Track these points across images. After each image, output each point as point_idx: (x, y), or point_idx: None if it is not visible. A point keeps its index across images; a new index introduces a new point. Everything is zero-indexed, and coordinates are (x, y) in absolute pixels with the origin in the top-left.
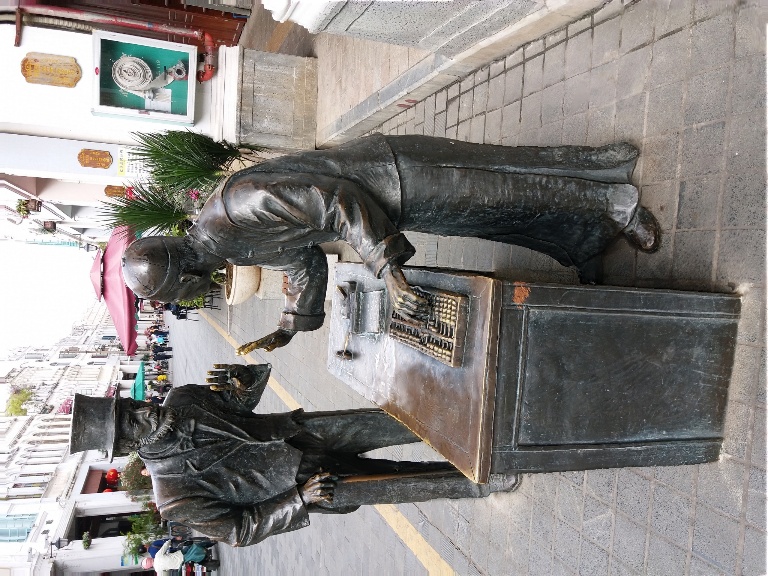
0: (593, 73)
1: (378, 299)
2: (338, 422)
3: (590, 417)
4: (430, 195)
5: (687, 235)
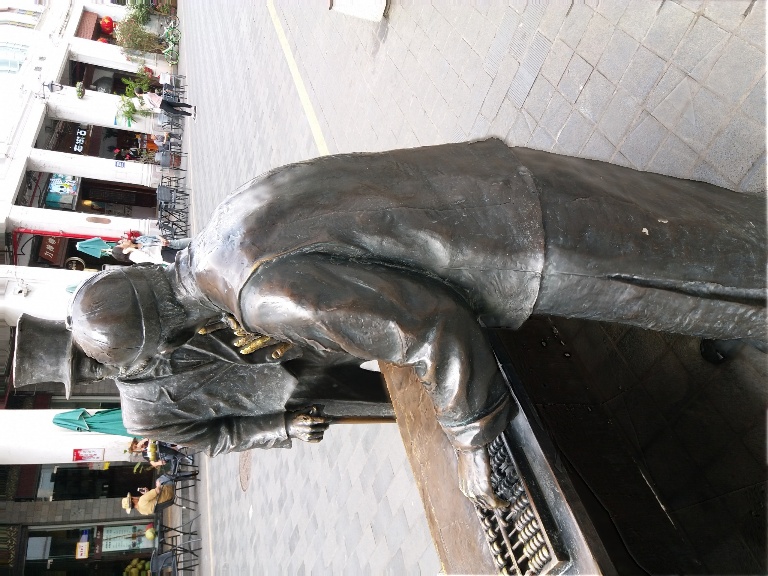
0: None
1: None
2: None
3: None
4: (573, 310)
5: None
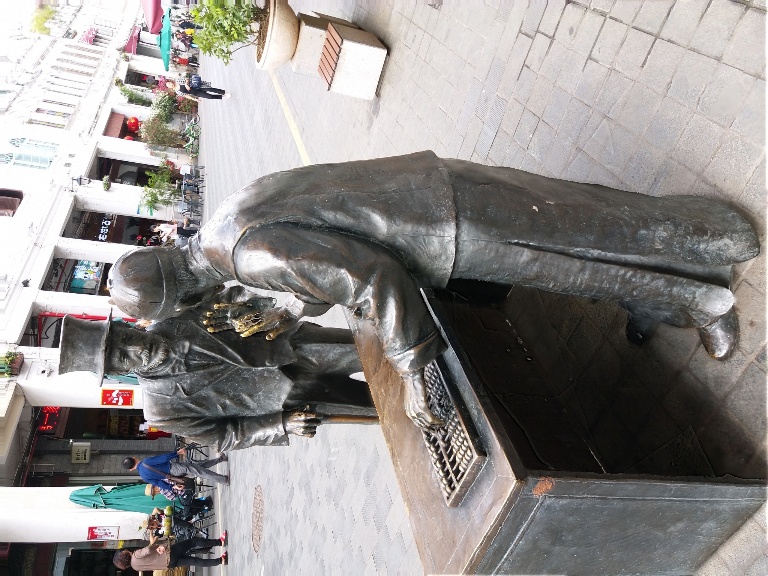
0: (759, 86)
1: None
2: (336, 349)
3: (570, 569)
4: (487, 272)
5: (763, 376)
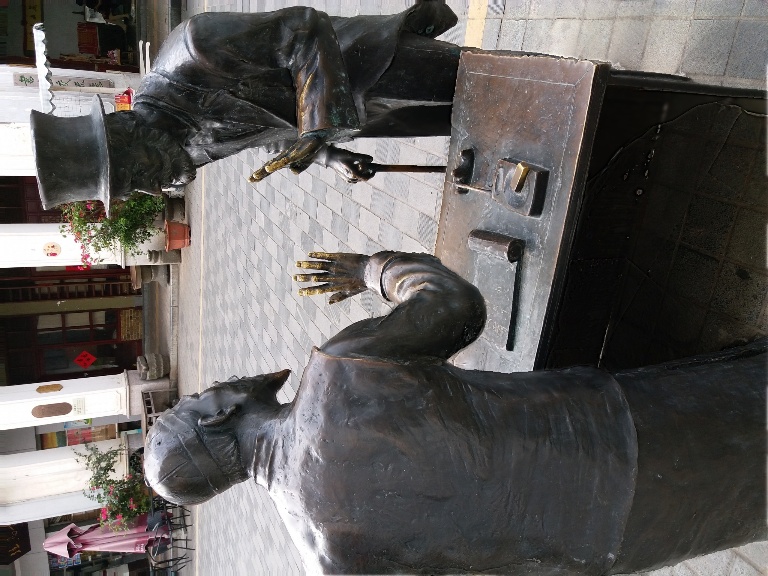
0: None
1: (498, 341)
2: None
3: None
4: None
5: None
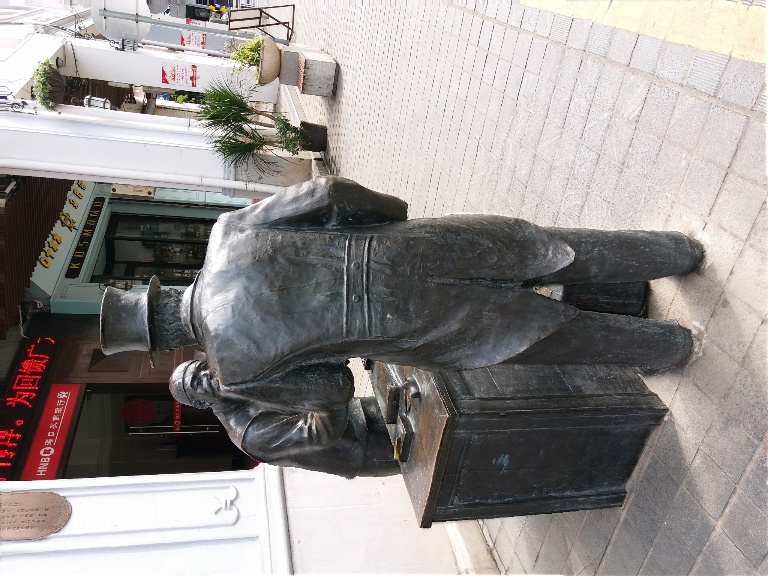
0: None
1: (377, 382)
2: None
3: None
4: None
5: None
